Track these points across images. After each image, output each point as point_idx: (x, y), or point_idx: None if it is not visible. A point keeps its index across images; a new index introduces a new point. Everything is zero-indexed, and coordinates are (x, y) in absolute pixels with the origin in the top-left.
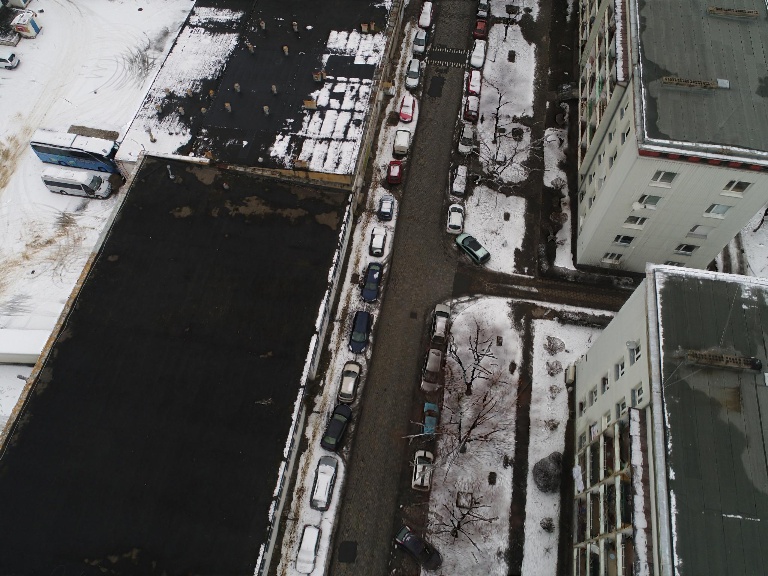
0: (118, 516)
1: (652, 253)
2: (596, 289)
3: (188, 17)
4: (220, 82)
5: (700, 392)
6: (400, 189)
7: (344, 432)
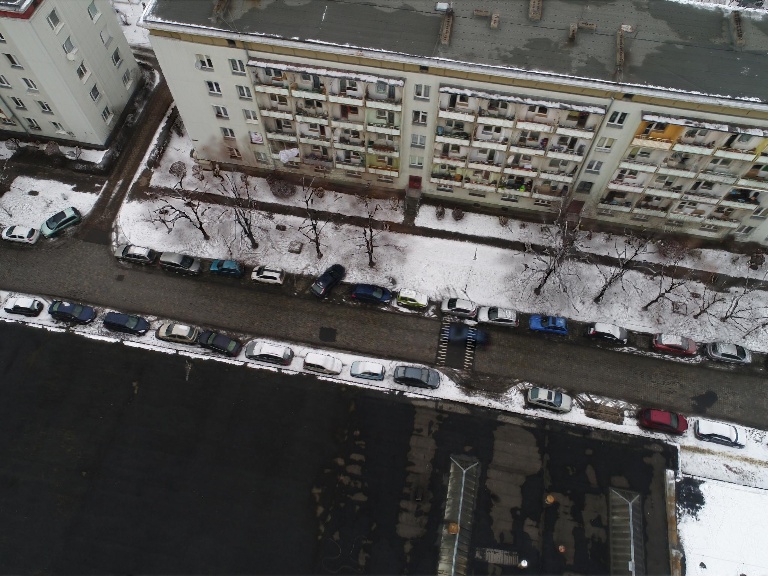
0: (281, 514)
1: (112, 83)
2: (132, 139)
3: None
4: None
5: (244, 15)
6: None
7: None
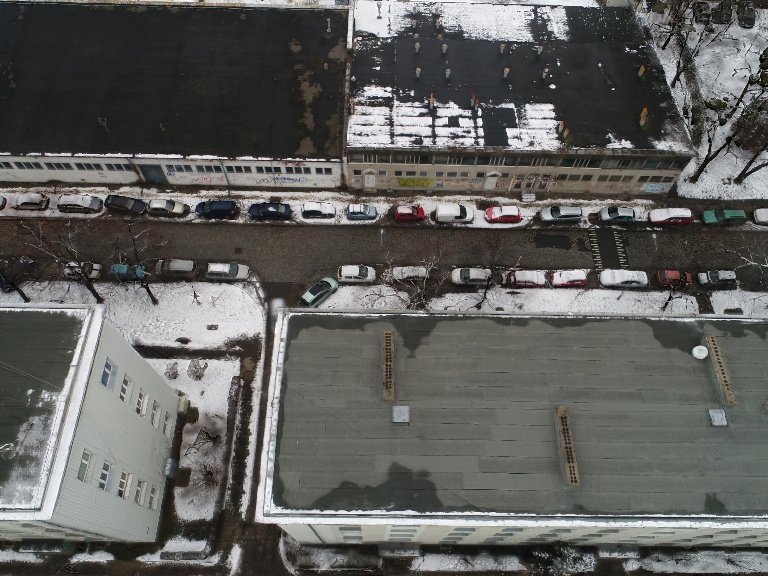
0: (39, 71)
1: None
2: None
3: (547, 5)
4: (454, 39)
5: None
6: (390, 223)
7: (122, 212)
